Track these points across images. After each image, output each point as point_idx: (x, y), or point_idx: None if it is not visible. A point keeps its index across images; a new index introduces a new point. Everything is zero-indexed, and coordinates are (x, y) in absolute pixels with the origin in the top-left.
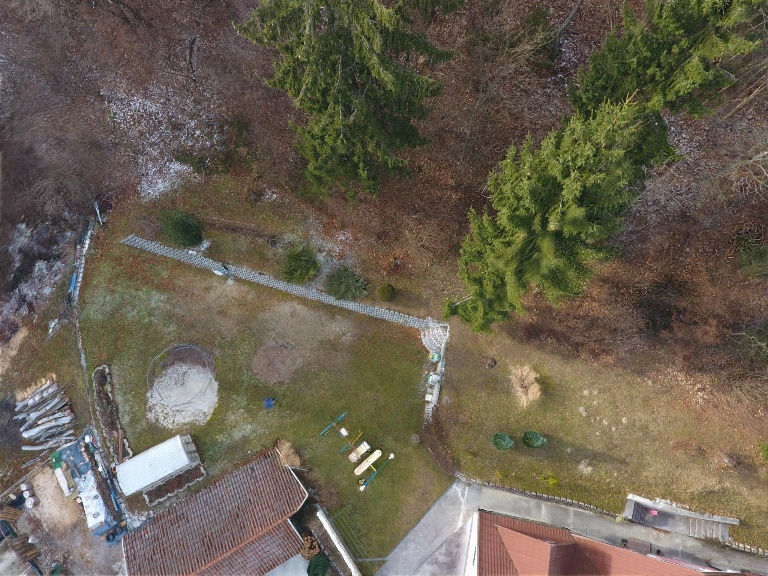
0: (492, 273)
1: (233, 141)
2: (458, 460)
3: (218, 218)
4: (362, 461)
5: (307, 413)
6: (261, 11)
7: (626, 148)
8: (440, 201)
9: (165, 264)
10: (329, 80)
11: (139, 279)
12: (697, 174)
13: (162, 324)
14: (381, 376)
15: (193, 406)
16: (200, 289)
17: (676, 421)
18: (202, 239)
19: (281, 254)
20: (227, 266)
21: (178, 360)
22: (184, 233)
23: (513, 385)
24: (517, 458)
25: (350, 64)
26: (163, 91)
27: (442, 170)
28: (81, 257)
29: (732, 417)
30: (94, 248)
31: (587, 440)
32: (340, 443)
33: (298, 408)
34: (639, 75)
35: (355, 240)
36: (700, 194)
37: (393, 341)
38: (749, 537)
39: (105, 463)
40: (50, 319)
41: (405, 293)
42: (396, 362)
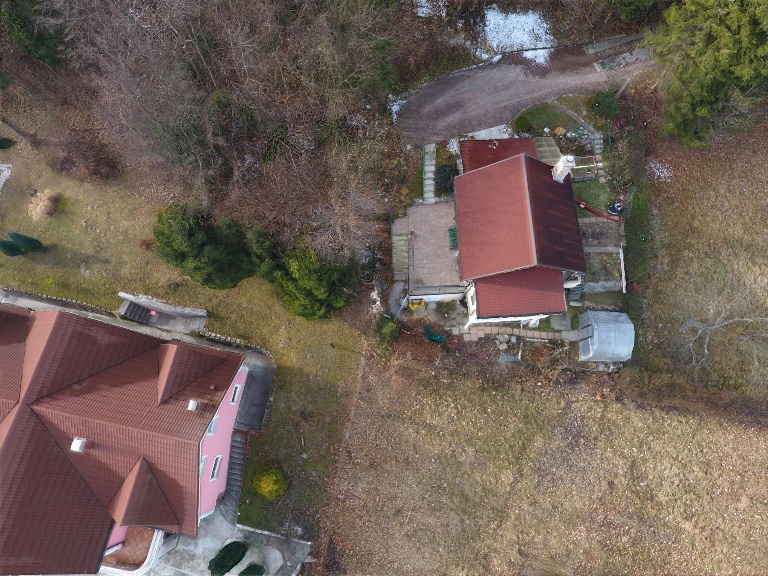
0: None
1: None
2: None
3: None
4: None
5: None
6: None
7: None
8: (3, 56)
9: None
10: None
11: None
12: None
13: None
14: None
15: None
16: None
17: (149, 225)
18: None
19: None
20: None
21: None
22: None
23: None
24: (34, 267)
25: None
26: None
27: (1, 28)
28: None
29: None
30: None
31: (81, 245)
32: None
33: None
34: None
35: None
36: None
37: None
38: (222, 328)
39: None
40: None
41: None
42: None
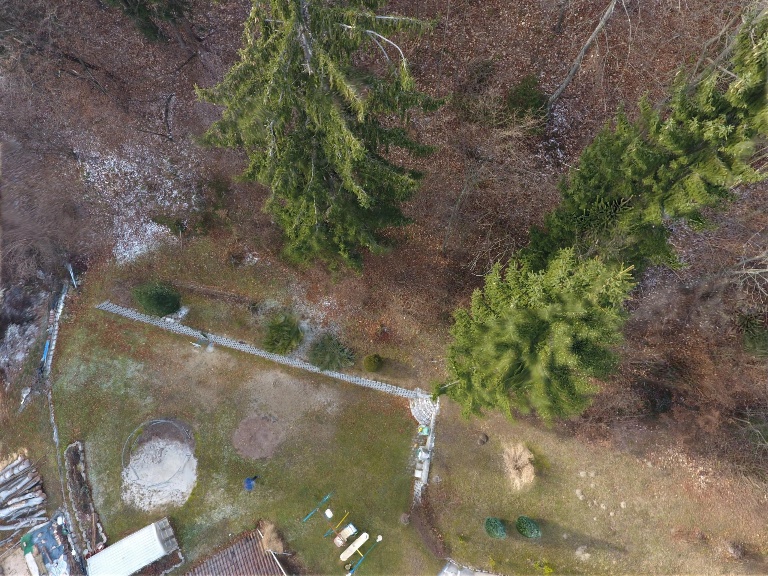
0: (480, 371)
1: (212, 202)
2: (449, 545)
3: (196, 286)
4: (348, 545)
5: (291, 492)
6: (221, 124)
7: (621, 246)
8: (428, 267)
9: (142, 330)
10: (301, 179)
11: (115, 347)
12: (696, 245)
13: (139, 396)
14: (368, 450)
15: (171, 486)
16: (179, 357)
17: (677, 507)
18: (180, 306)
19: (263, 321)
20: (206, 334)
21: (155, 435)
22: (159, 306)
23: (506, 464)
24: (511, 543)
25: (323, 166)
26: (138, 150)
27: (430, 235)
28: (54, 323)
29: (736, 503)
30: (68, 313)
31: (584, 526)
32: (325, 524)
33: (281, 486)
34: (634, 181)
35: (340, 306)
36: (700, 266)
37: (381, 412)
38: None
39: (78, 549)
40: (23, 387)
41: (393, 362)
42: (384, 435)
